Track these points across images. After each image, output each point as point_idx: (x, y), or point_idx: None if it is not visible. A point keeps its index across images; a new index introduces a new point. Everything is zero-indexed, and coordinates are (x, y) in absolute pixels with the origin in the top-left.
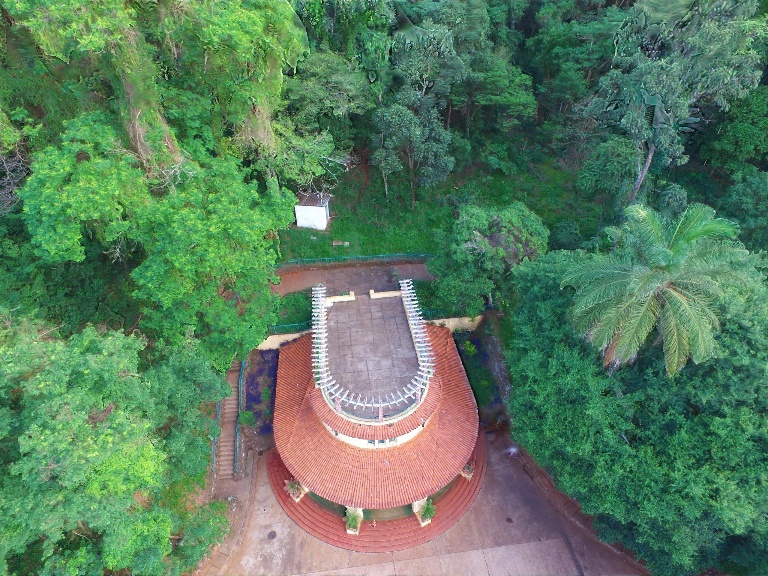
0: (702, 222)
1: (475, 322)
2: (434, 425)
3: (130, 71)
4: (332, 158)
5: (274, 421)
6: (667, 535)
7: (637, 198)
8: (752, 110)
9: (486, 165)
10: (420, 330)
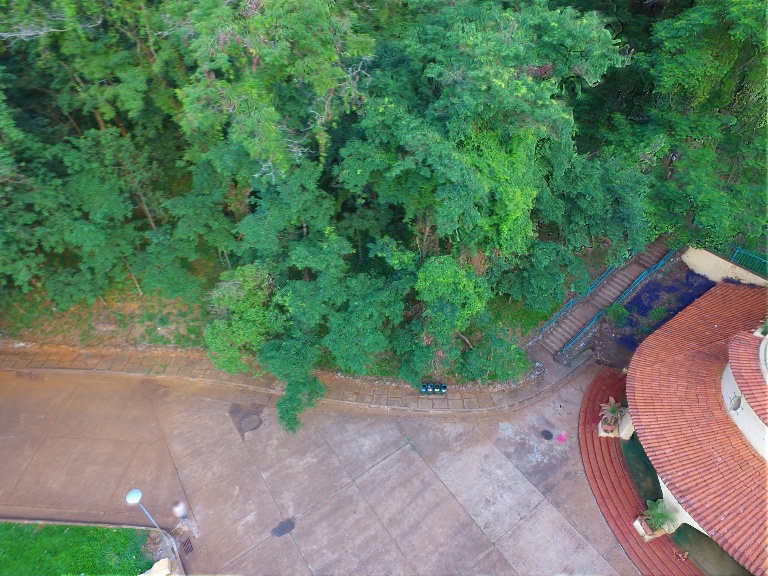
0: None
1: None
2: None
3: None
4: None
5: (650, 336)
6: None
7: None
8: None
9: None
10: None
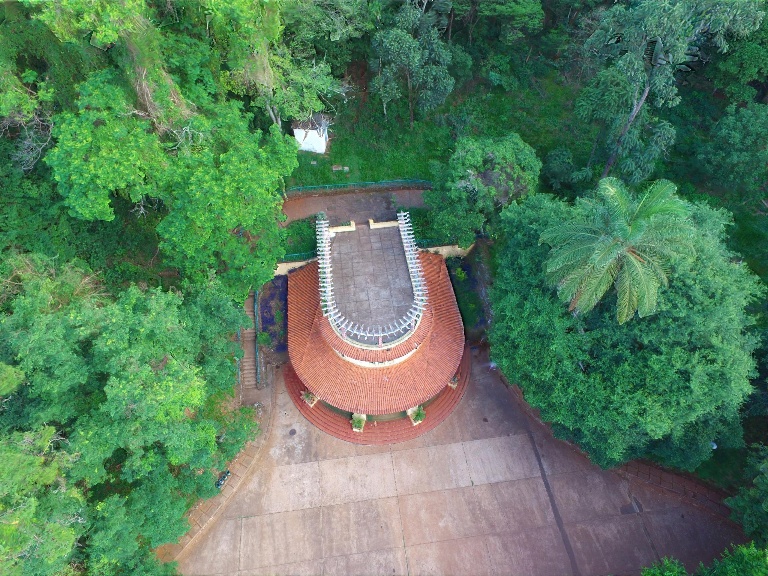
0: (662, 200)
1: (467, 249)
2: (426, 347)
3: None
4: (330, 87)
5: (288, 342)
6: (605, 437)
7: (629, 131)
8: (763, 29)
9: (487, 80)
10: (415, 265)
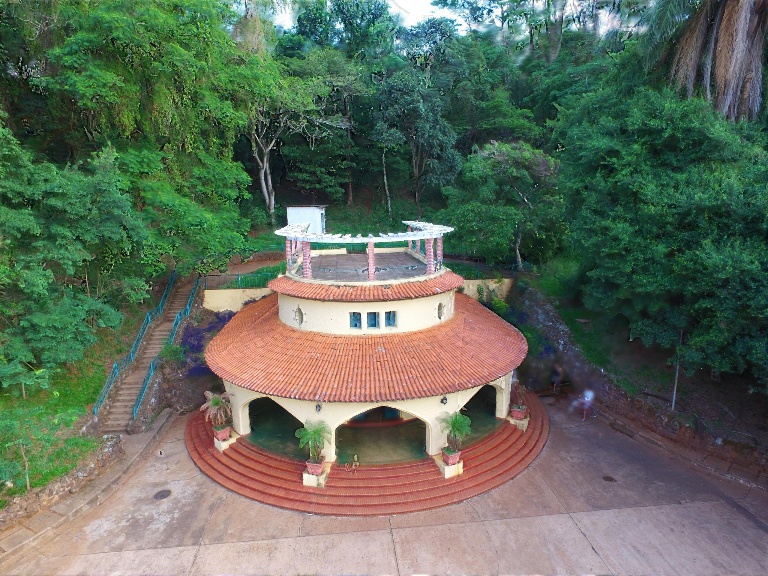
0: None
1: (503, 289)
2: (457, 325)
3: None
4: (329, 122)
5: (211, 341)
6: None
7: None
8: None
9: None
10: None
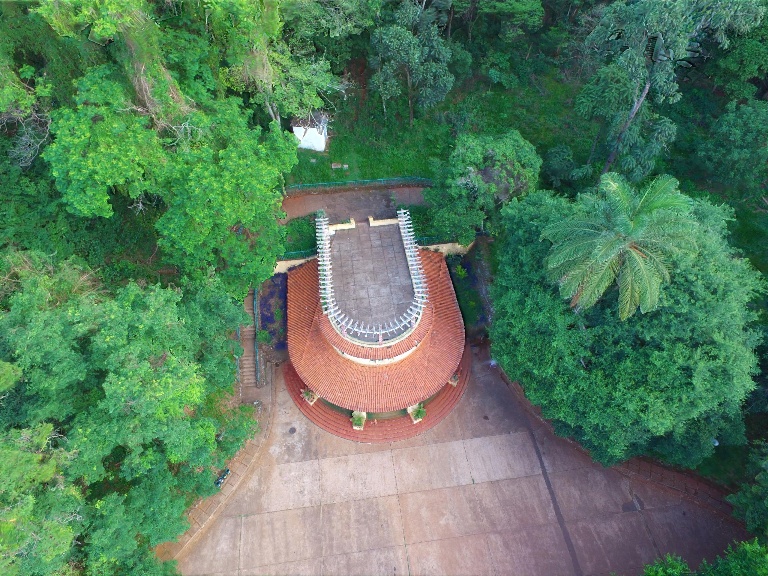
0: (664, 195)
1: (467, 247)
2: (426, 344)
3: (129, 22)
4: (330, 84)
5: (288, 340)
6: (606, 435)
7: (630, 128)
8: (763, 26)
9: (487, 78)
10: (416, 262)
